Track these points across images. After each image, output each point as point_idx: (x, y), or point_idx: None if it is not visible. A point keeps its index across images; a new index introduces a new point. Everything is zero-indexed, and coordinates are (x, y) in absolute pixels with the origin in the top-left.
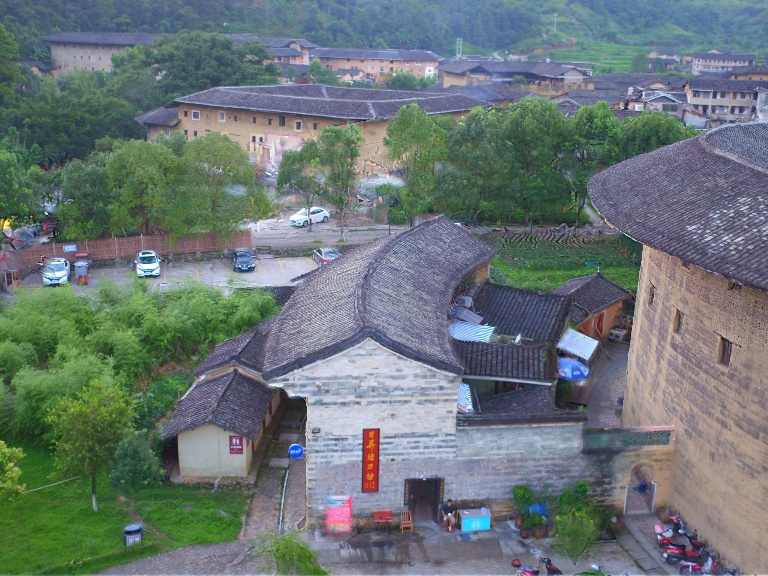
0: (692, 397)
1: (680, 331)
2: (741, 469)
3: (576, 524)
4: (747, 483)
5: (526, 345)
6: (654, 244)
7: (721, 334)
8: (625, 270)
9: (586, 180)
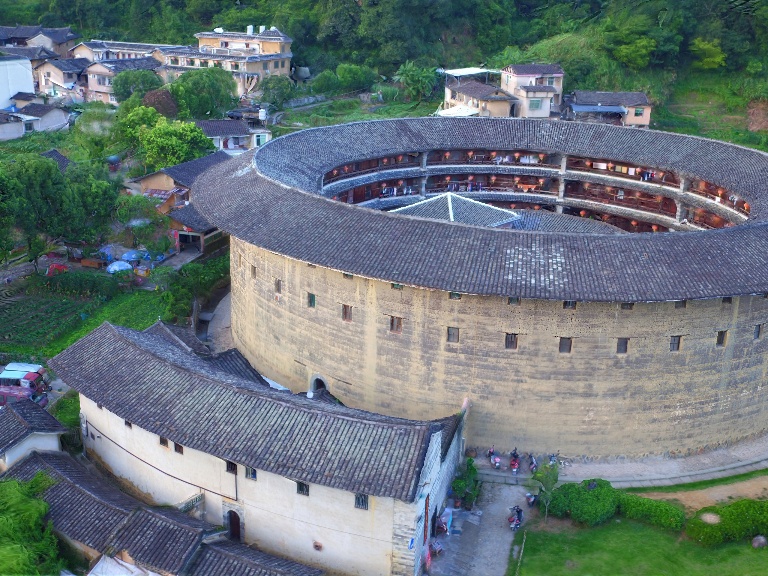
0: (484, 375)
1: (452, 340)
2: (540, 400)
3: (553, 471)
4: (545, 406)
5: (315, 397)
6: (504, 294)
7: (507, 332)
8: (110, 309)
9: (11, 237)
